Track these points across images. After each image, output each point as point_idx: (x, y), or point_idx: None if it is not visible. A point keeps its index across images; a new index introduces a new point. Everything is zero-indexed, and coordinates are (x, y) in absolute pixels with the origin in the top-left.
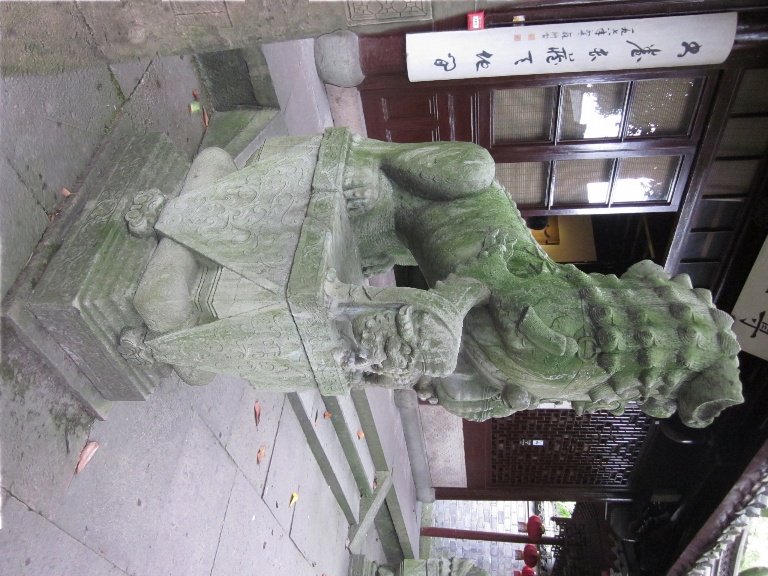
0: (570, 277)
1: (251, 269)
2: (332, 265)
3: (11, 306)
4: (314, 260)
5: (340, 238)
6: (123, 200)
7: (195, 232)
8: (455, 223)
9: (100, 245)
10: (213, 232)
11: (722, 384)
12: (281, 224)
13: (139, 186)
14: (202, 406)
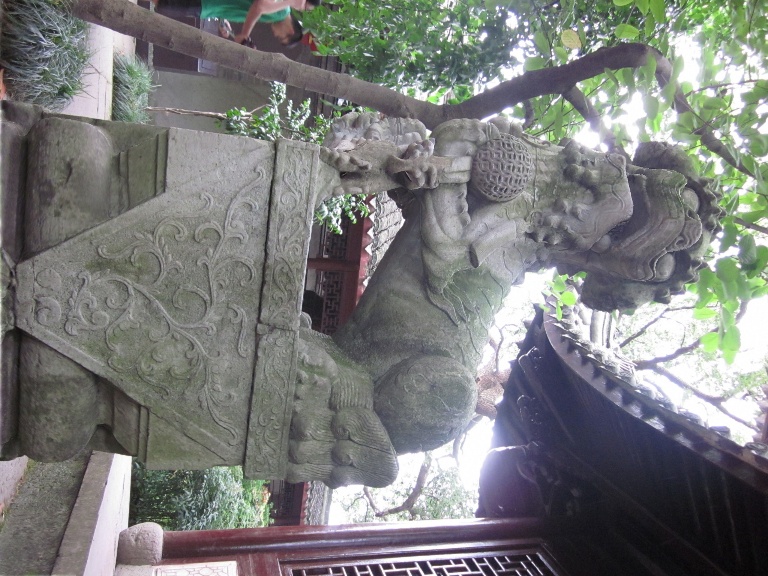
0: None
1: None
2: None
3: None
4: None
5: None
6: None
7: None
8: None
9: None
10: None
11: None
12: None
13: None
14: None
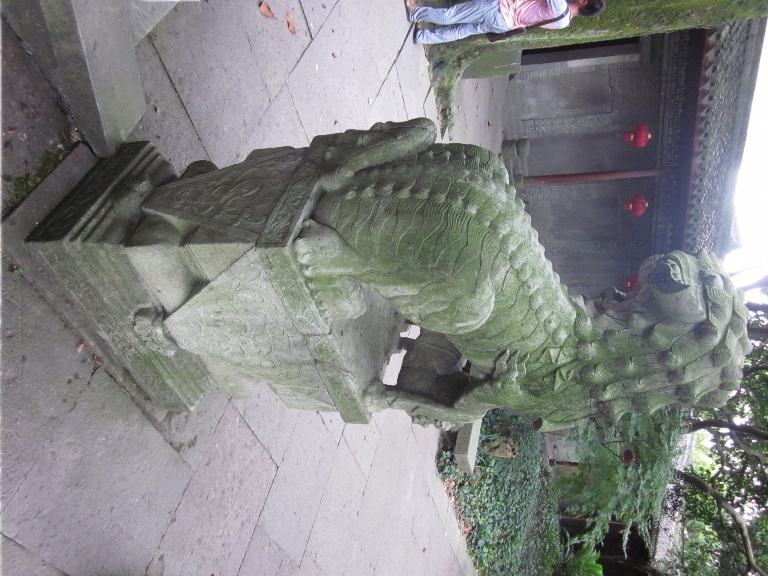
0: (583, 378)
1: (298, 391)
2: (361, 379)
3: (157, 420)
4: (349, 401)
5: (351, 339)
6: (128, 334)
7: (221, 355)
8: (461, 339)
9: (160, 374)
10: (237, 356)
11: (710, 403)
12: (294, 357)
13: (121, 312)
14: (240, 136)
